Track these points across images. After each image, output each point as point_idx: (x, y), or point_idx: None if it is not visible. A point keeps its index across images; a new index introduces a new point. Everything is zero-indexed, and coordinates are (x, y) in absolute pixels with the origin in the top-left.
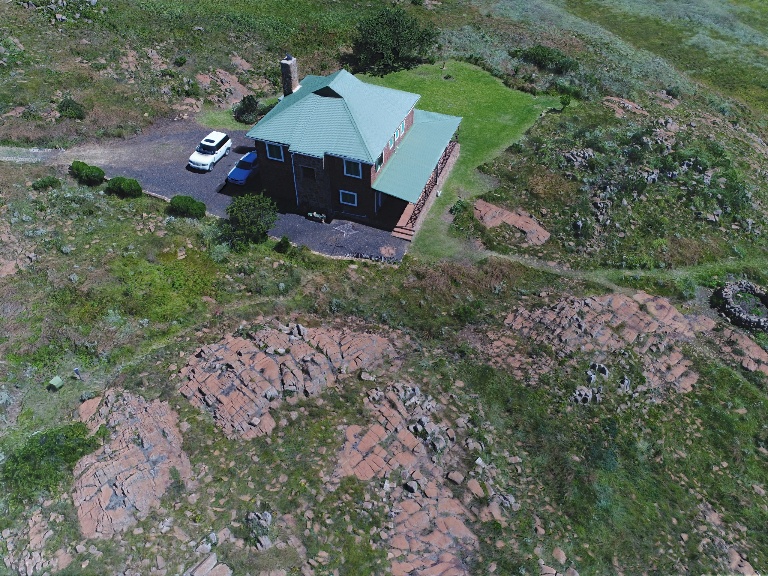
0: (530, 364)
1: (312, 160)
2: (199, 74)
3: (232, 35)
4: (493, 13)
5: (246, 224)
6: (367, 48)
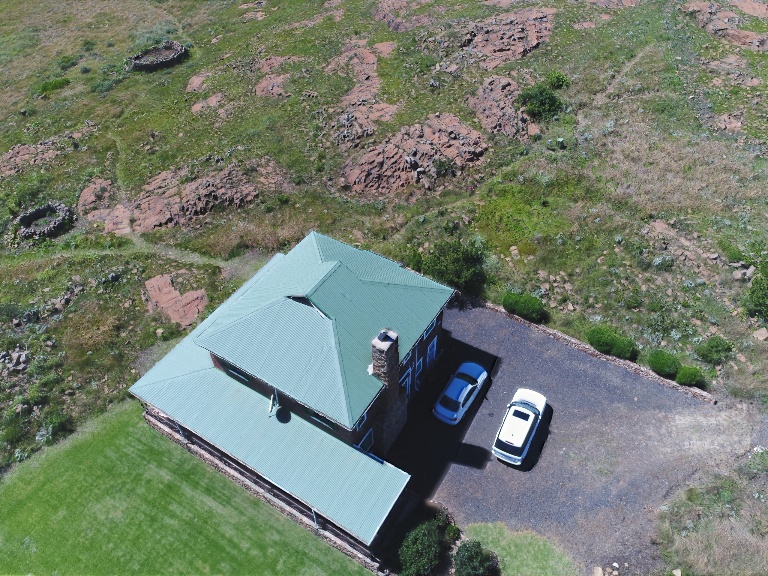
0: (261, 164)
1: None
2: None
3: None
4: None
5: None
6: None
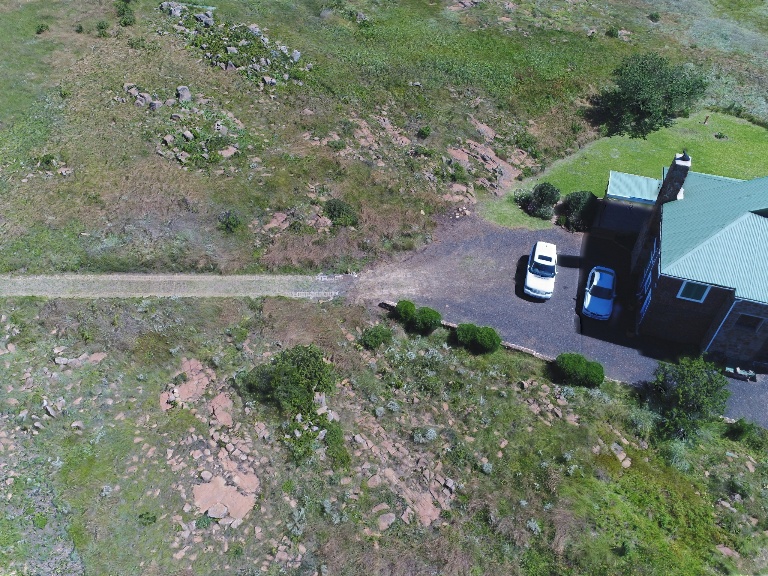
0: None
1: (767, 309)
2: (449, 148)
3: (453, 90)
4: (694, 43)
5: (709, 412)
6: (625, 104)
